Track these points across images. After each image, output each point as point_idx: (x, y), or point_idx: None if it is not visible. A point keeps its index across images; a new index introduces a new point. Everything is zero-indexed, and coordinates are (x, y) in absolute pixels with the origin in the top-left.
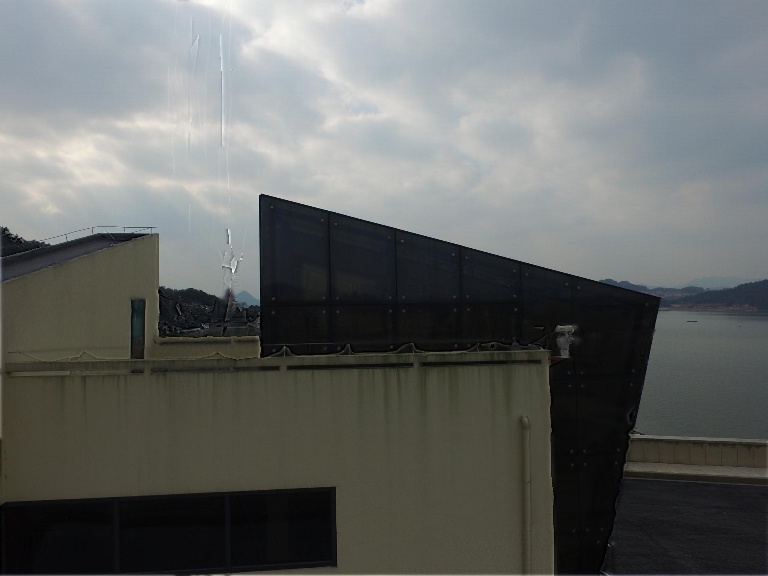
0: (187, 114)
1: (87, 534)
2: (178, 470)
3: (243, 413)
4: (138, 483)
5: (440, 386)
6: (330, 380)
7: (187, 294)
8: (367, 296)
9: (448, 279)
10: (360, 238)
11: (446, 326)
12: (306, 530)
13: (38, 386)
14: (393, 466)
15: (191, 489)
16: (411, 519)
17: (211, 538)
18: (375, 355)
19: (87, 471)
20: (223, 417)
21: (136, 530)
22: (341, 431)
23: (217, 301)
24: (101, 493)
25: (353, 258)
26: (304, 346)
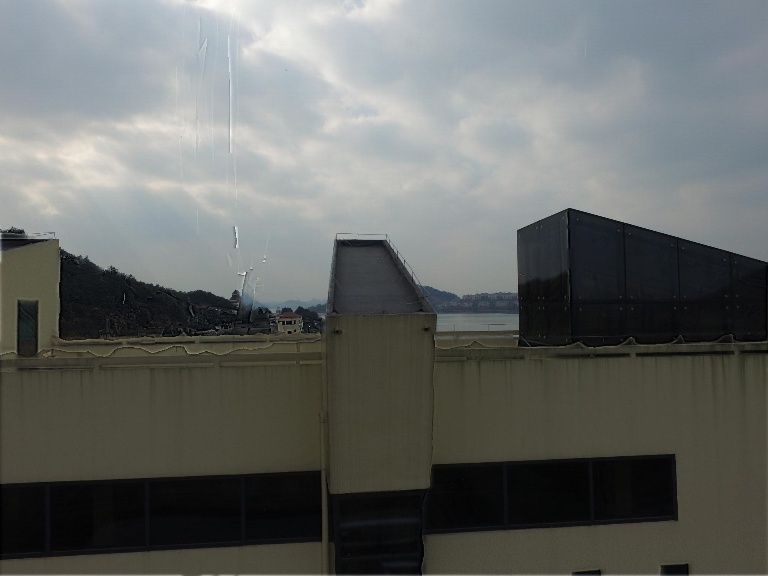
0: (194, 117)
1: (478, 493)
2: (551, 439)
3: (601, 392)
4: (521, 450)
5: (756, 370)
6: (670, 365)
7: (196, 296)
8: (652, 295)
9: (717, 281)
10: (643, 246)
11: (715, 321)
12: (646, 491)
13: (443, 369)
14: (719, 437)
15: (562, 455)
16: (734, 481)
17: (577, 496)
18: (703, 344)
19: (481, 440)
20: (586, 396)
21: (520, 489)
22: (678, 408)
23: (241, 303)
24: (492, 458)
25: (637, 263)
26: (597, 338)
